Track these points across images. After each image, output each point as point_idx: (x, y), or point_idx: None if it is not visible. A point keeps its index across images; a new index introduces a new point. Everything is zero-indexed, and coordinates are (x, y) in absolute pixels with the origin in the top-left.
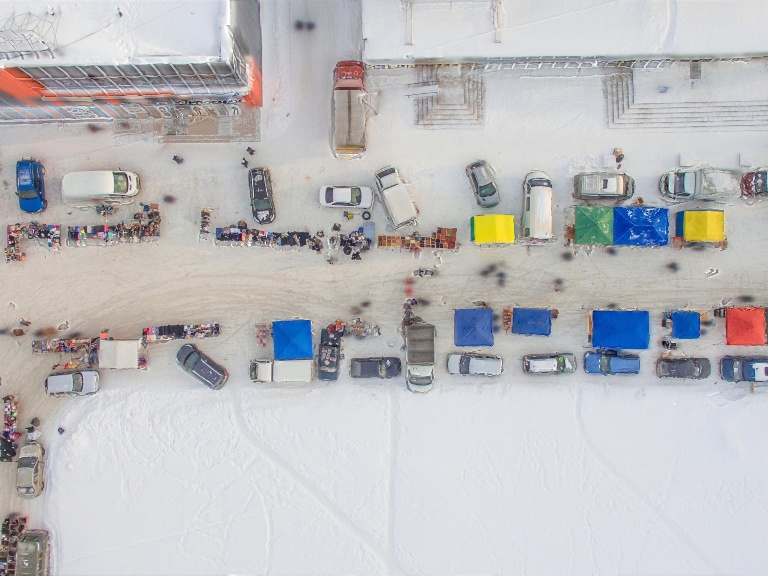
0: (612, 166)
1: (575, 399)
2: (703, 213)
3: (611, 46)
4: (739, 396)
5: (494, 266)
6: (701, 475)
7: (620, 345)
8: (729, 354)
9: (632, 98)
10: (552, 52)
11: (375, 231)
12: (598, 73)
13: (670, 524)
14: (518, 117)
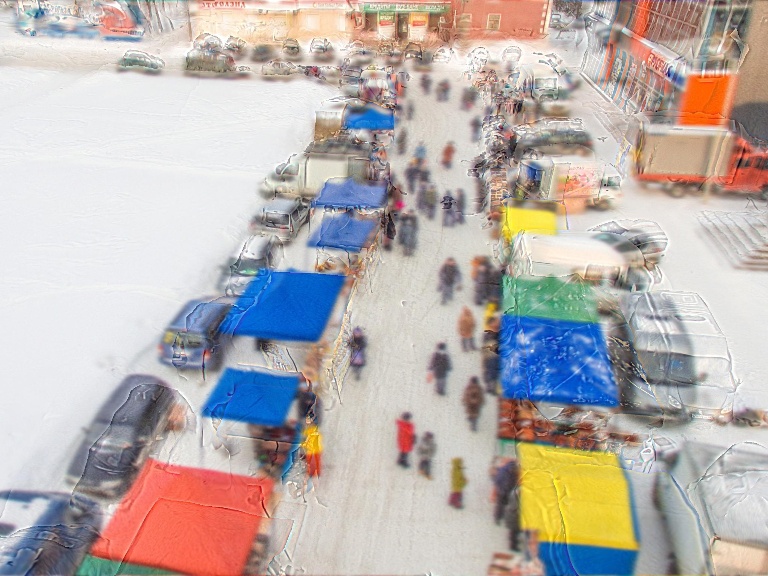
0: (746, 401)
1: (170, 290)
2: (681, 506)
3: None
4: None
5: (459, 251)
6: None
7: None
8: None
9: None
10: None
11: (512, 175)
12: None
13: None
14: None
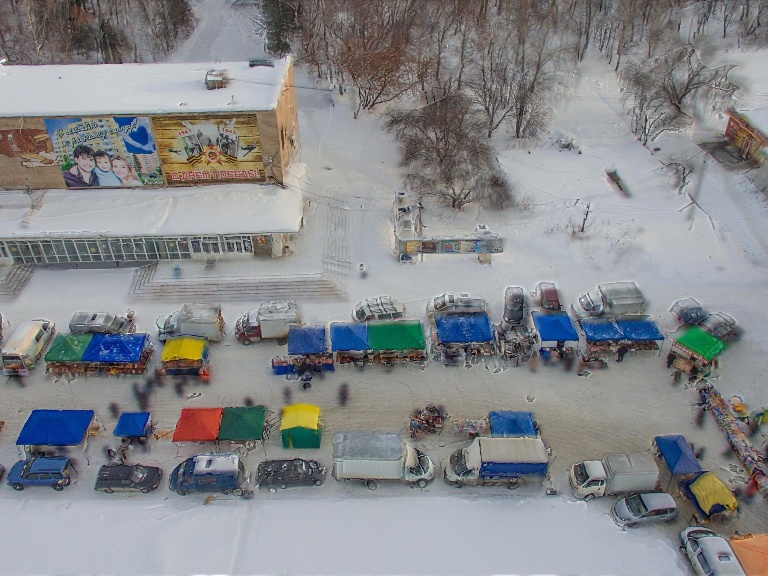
0: None
1: None
2: (182, 337)
3: (118, 226)
4: (186, 508)
5: None
6: None
7: (47, 442)
8: None
9: (153, 276)
10: (68, 229)
11: None
12: (134, 266)
13: None
14: (52, 291)
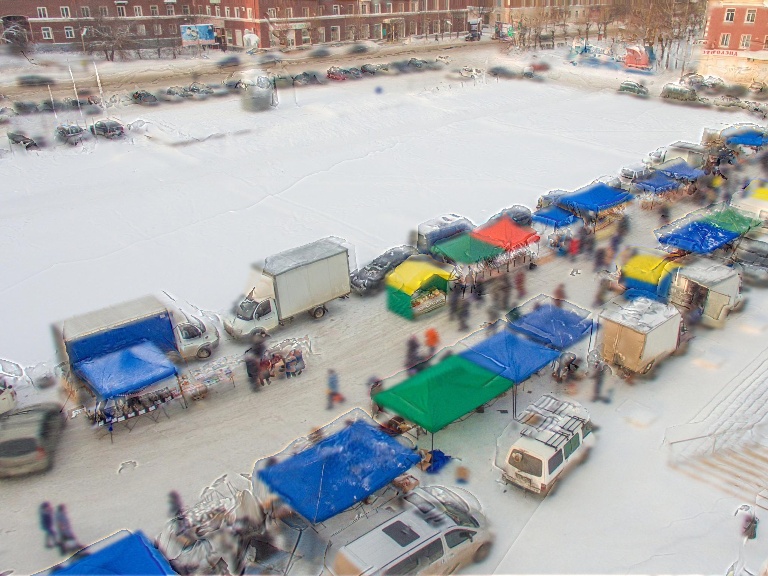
0: None
1: None
2: None
3: None
4: None
5: None
6: None
7: None
8: None
9: None
10: None
11: None
12: None
13: None
14: None
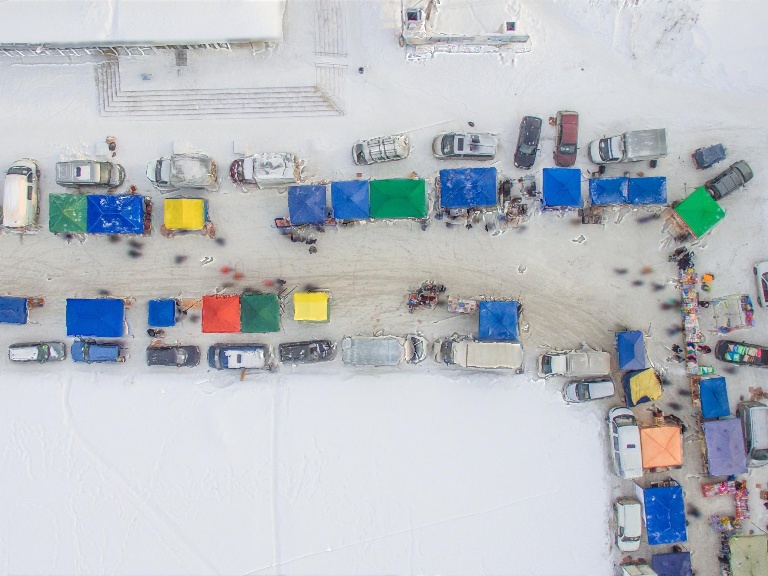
0: (104, 154)
1: (64, 387)
2: (179, 201)
3: (56, 33)
4: (228, 384)
5: None
6: (188, 462)
7: (94, 333)
8: (220, 342)
9: (119, 86)
10: None
11: None
12: (90, 61)
13: (158, 511)
14: (9, 105)
